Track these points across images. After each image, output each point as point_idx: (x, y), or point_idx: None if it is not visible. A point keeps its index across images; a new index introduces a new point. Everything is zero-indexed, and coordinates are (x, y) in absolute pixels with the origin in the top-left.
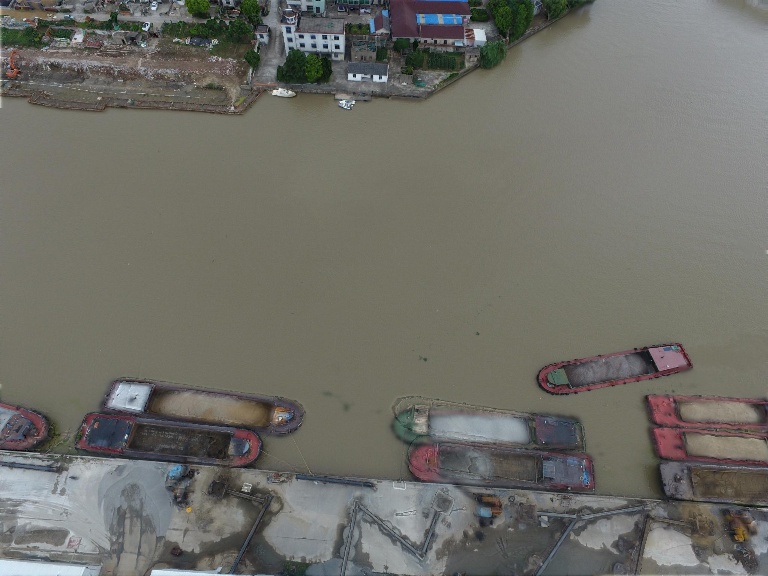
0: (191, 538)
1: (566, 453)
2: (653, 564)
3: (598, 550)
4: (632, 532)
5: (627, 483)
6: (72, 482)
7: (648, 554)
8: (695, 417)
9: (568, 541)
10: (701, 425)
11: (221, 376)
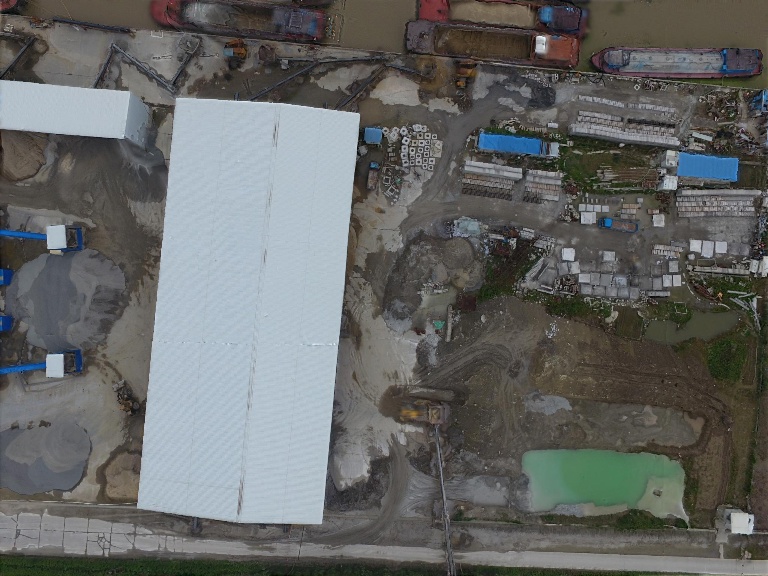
0: None
1: (321, 10)
2: (379, 103)
3: (333, 91)
4: (367, 79)
5: (379, 42)
6: None
7: (377, 96)
8: None
9: (307, 84)
10: None
11: None
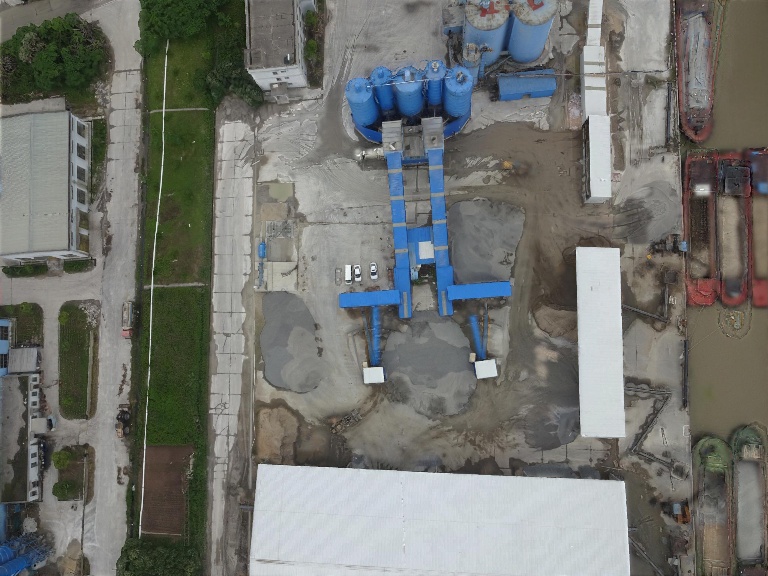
0: (628, 263)
1: None
2: None
3: None
4: None
5: None
6: (659, 159)
7: None
8: None
9: None
10: None
11: (766, 254)
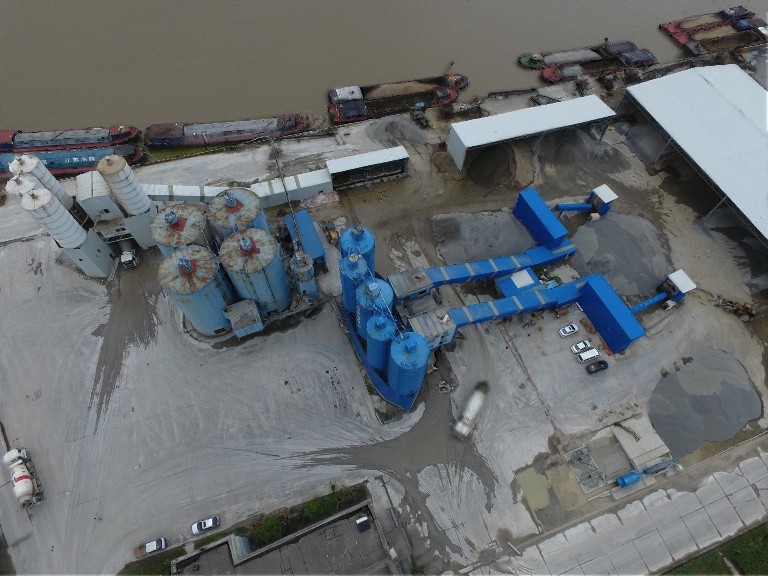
0: None
1: None
2: None
3: None
4: None
5: None
6: (346, 137)
7: None
8: (689, 25)
9: None
10: (694, 28)
11: (398, 75)
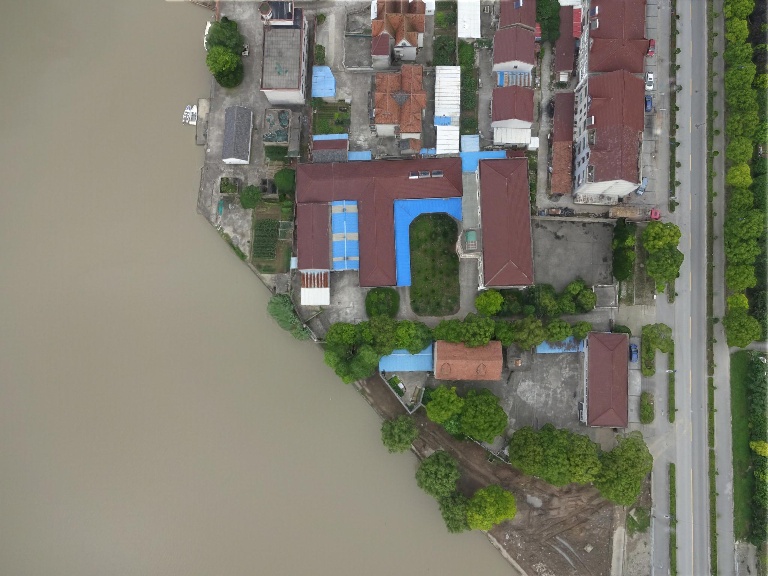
0: None
1: None
2: None
3: None
4: None
5: None
6: None
7: None
8: None
9: None
10: None
11: None
